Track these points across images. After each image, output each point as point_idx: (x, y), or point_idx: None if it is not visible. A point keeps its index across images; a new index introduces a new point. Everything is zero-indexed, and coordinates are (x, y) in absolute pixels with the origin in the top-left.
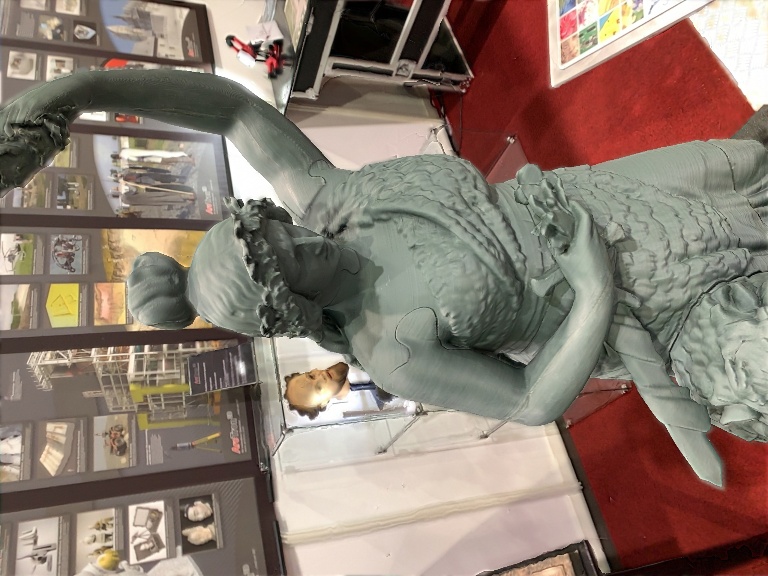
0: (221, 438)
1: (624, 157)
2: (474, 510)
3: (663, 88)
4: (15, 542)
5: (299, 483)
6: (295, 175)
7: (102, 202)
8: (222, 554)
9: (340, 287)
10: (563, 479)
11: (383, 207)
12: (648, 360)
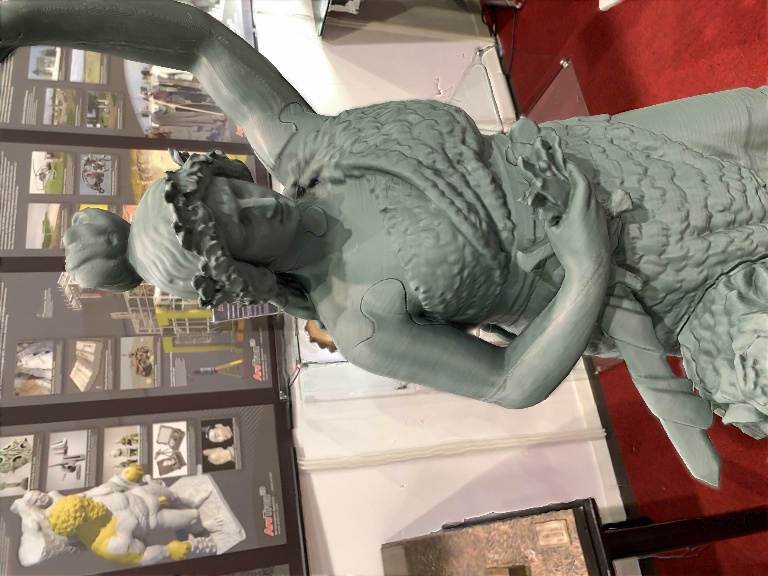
0: (243, 365)
1: (653, 106)
2: (492, 449)
3: (739, 9)
4: (47, 451)
5: (318, 412)
6: (264, 120)
7: (132, 121)
8: (240, 475)
9: (302, 251)
10: (587, 424)
11: (355, 162)
12: (646, 348)
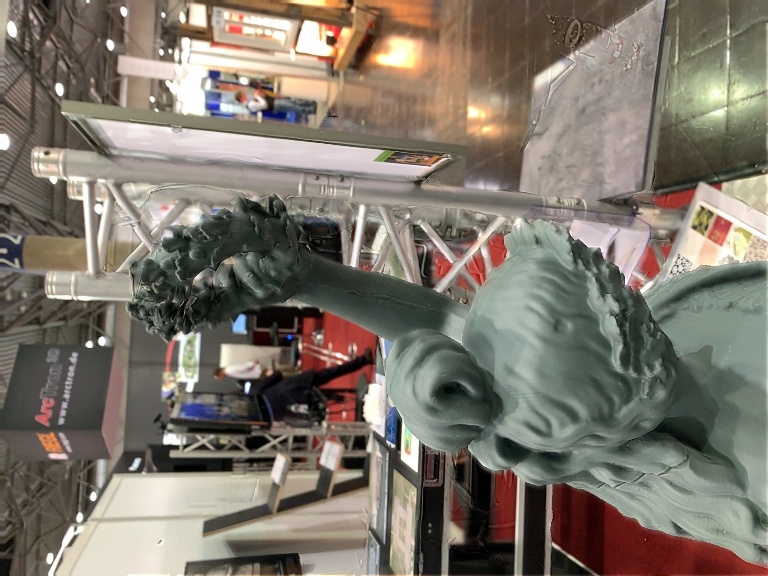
0: None
1: None
2: None
3: None
4: None
5: None
6: None
7: None
8: None
9: None
10: None
11: (659, 301)
12: None
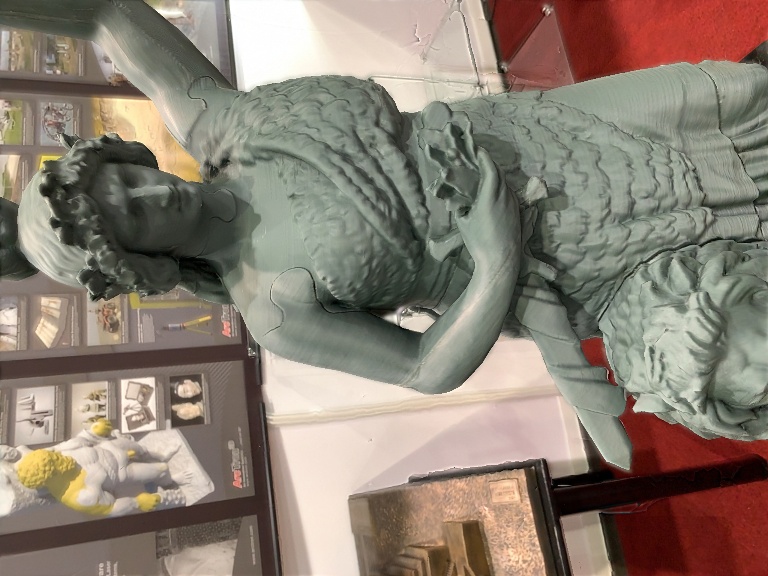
0: (212, 321)
1: None
2: (460, 404)
3: None
4: (14, 406)
5: (288, 368)
6: (172, 95)
7: (94, 68)
8: (209, 429)
9: (209, 237)
10: None
11: (262, 145)
12: (559, 338)
